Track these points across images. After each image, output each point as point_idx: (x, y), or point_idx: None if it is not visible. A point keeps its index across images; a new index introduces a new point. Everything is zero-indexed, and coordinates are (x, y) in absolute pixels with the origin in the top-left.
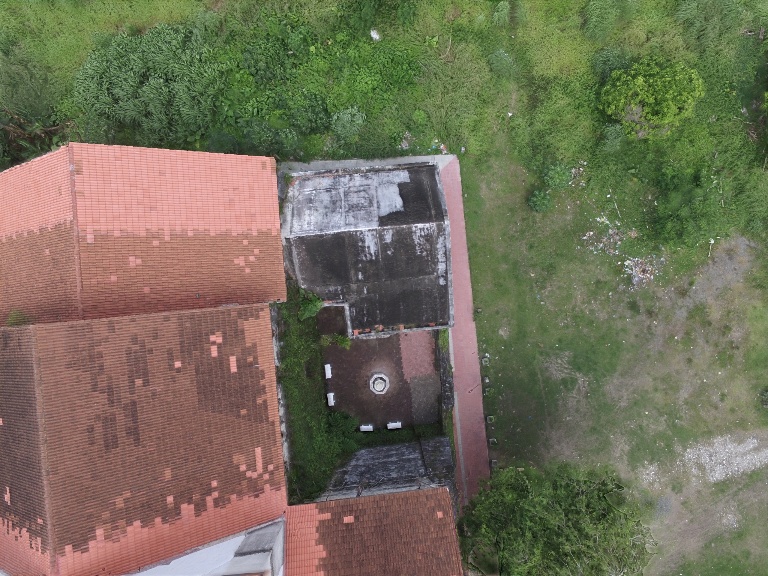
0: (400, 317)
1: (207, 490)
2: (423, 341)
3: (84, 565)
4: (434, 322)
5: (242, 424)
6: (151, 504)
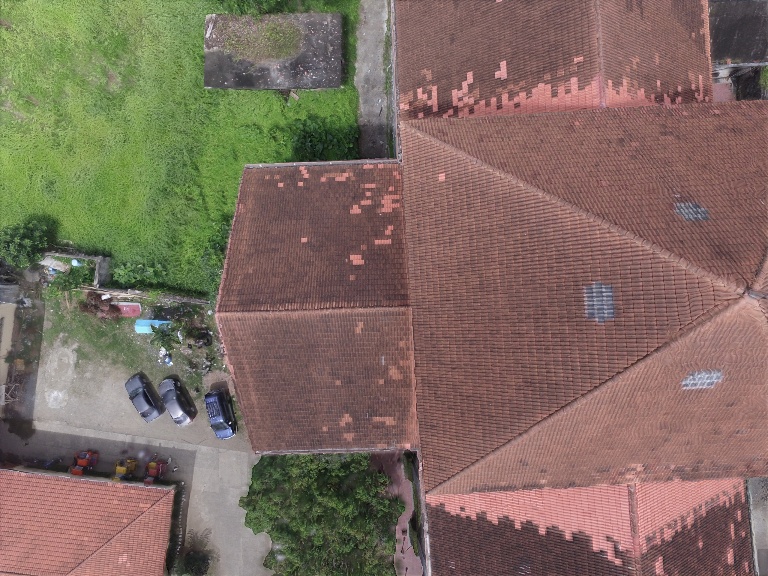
0: (730, 50)
1: (676, 92)
2: (724, 97)
3: (617, 106)
4: (759, 59)
5: (692, 46)
6: (649, 79)
